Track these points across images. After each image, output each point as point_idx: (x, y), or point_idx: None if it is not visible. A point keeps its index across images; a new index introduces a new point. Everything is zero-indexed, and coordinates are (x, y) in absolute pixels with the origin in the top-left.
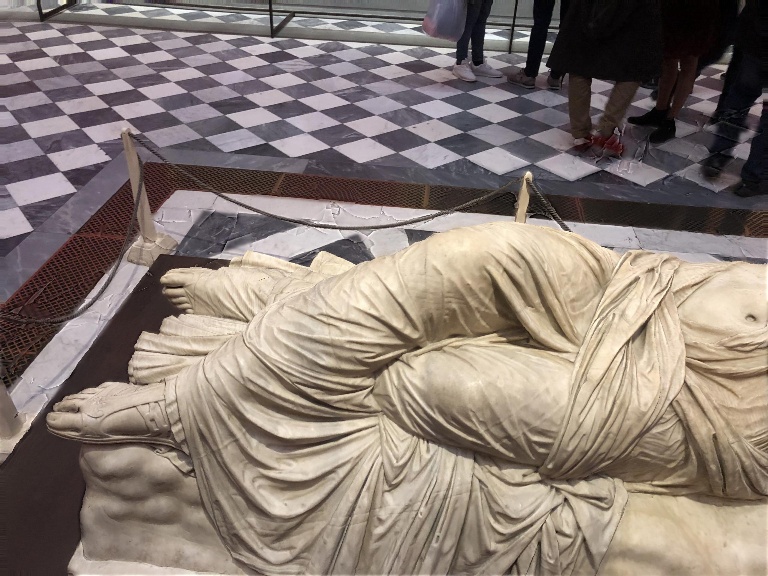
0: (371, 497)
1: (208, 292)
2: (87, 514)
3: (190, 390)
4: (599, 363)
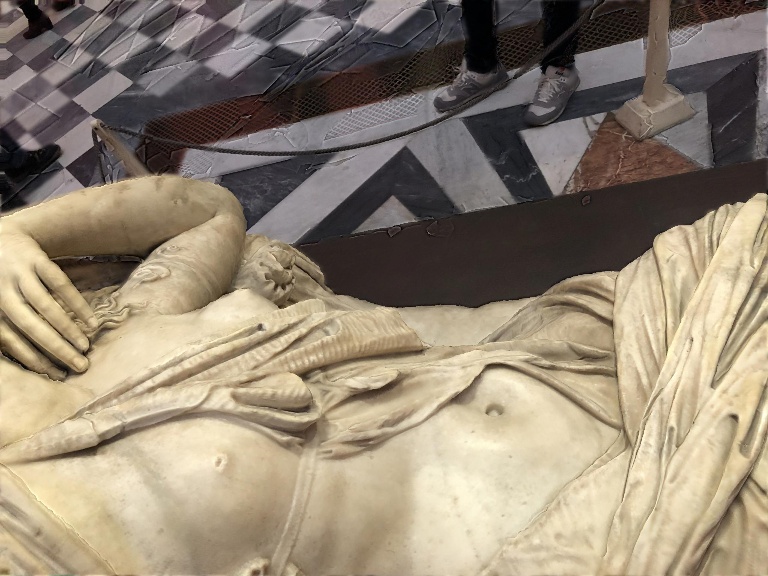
0: None
1: None
2: None
3: None
4: (756, 208)
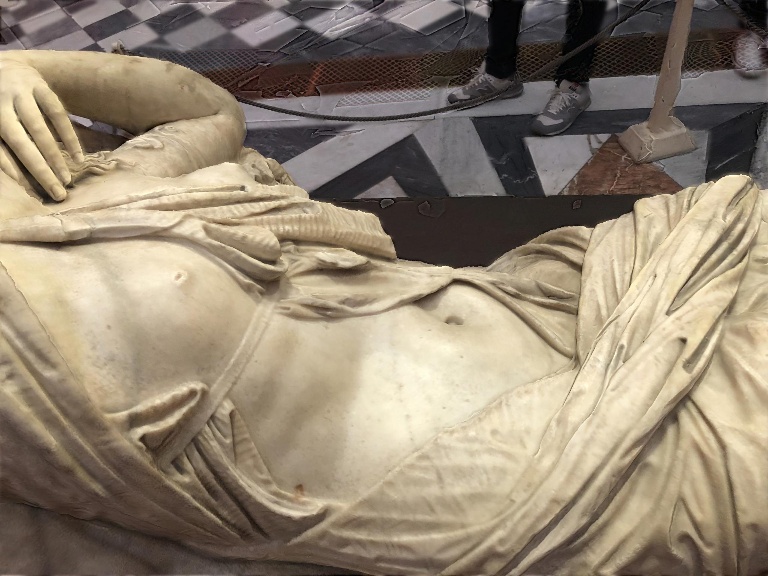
0: None
1: None
2: None
3: None
4: (736, 179)
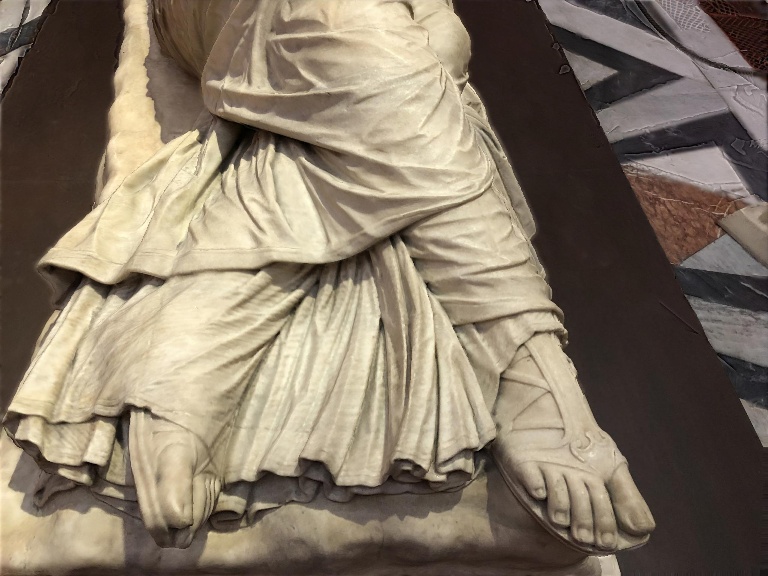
0: (502, 194)
1: (214, 412)
2: (597, 560)
3: (539, 291)
4: None
